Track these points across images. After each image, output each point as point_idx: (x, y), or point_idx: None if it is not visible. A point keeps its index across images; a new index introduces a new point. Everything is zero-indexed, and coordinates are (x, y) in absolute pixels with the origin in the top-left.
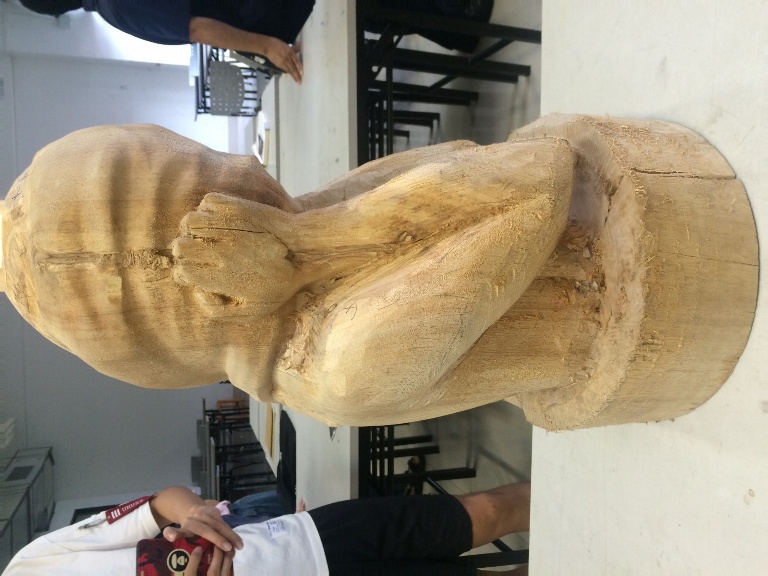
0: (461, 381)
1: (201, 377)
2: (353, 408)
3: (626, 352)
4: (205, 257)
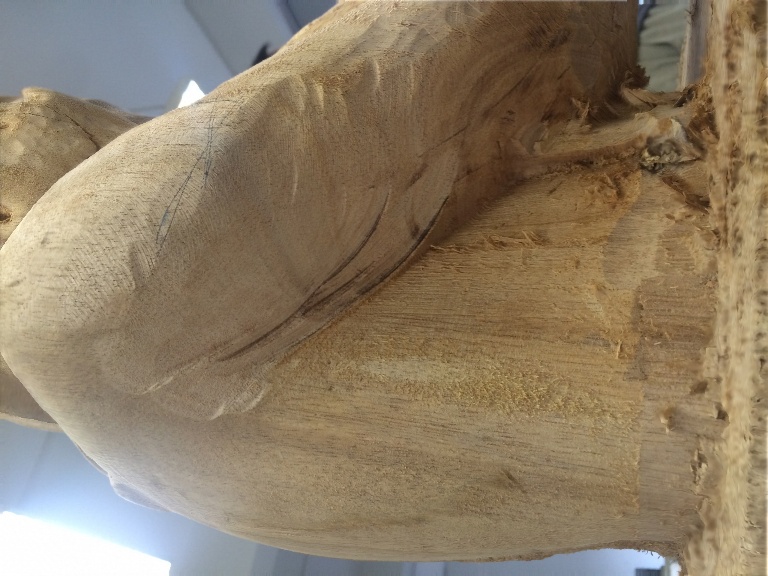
0: (310, 374)
1: (20, 396)
2: (3, 339)
3: (752, 235)
4: None
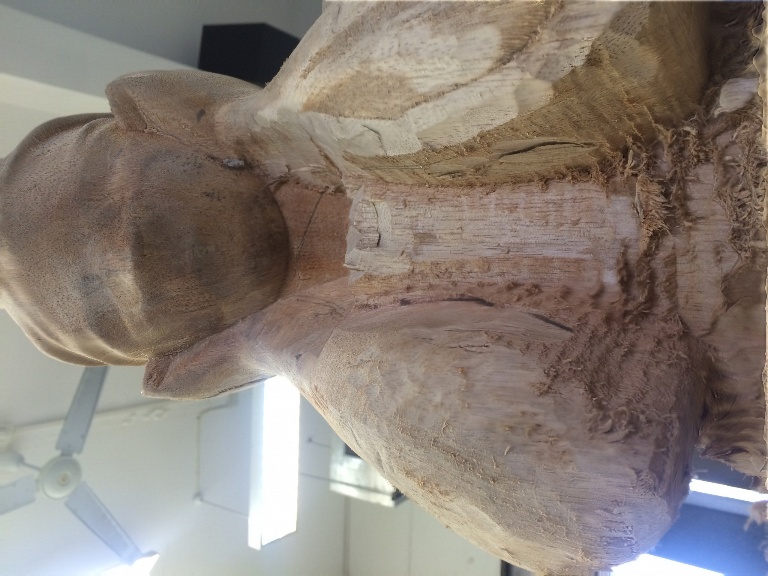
0: None
1: None
2: None
3: None
4: None
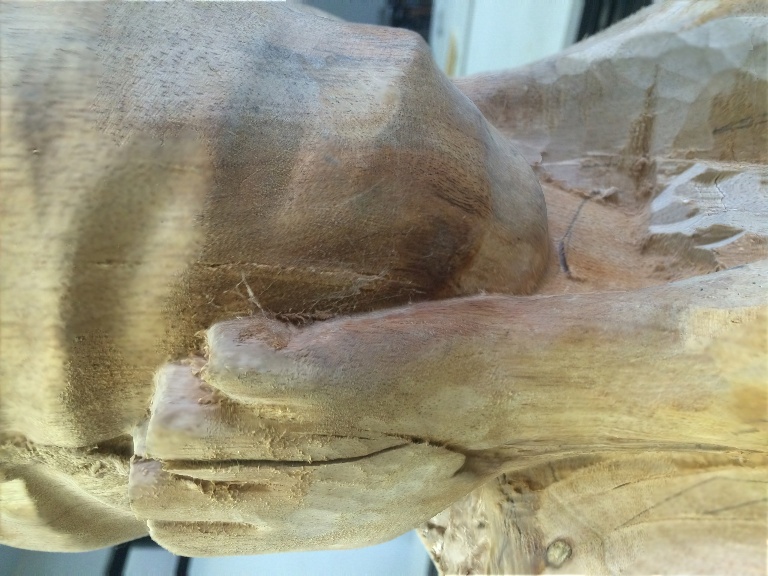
0: None
1: None
2: None
3: None
4: (215, 518)
